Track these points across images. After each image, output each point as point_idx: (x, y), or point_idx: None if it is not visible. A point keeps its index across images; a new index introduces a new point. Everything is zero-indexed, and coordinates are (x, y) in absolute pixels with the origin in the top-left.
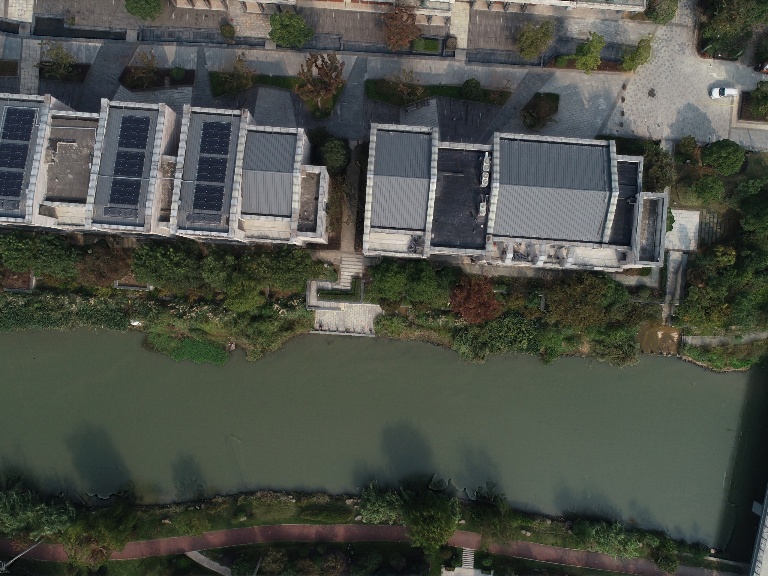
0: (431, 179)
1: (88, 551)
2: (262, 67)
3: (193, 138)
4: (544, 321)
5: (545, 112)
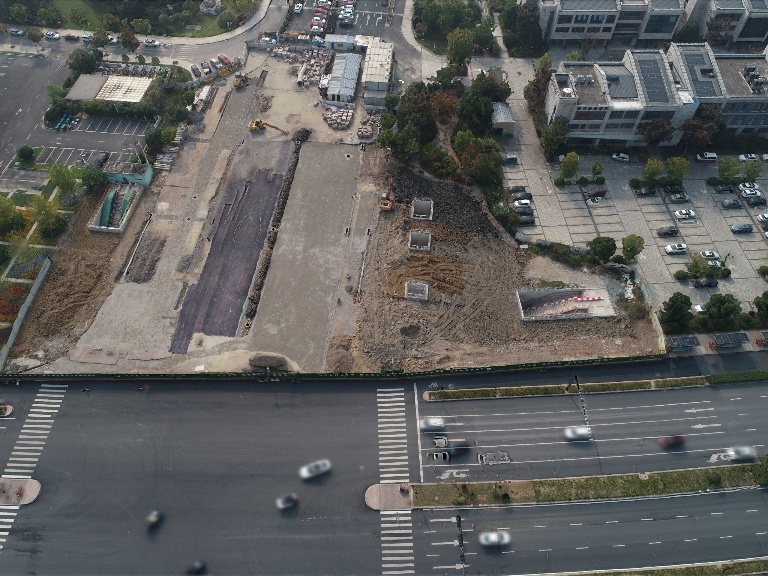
0: None
1: None
2: None
3: None
4: None
5: None
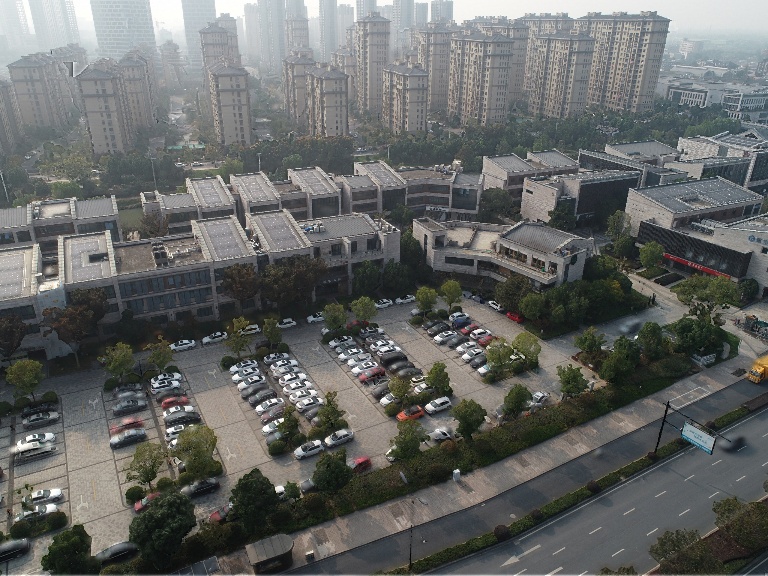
0: None
1: (226, 159)
2: None
3: (225, 198)
4: None
5: None
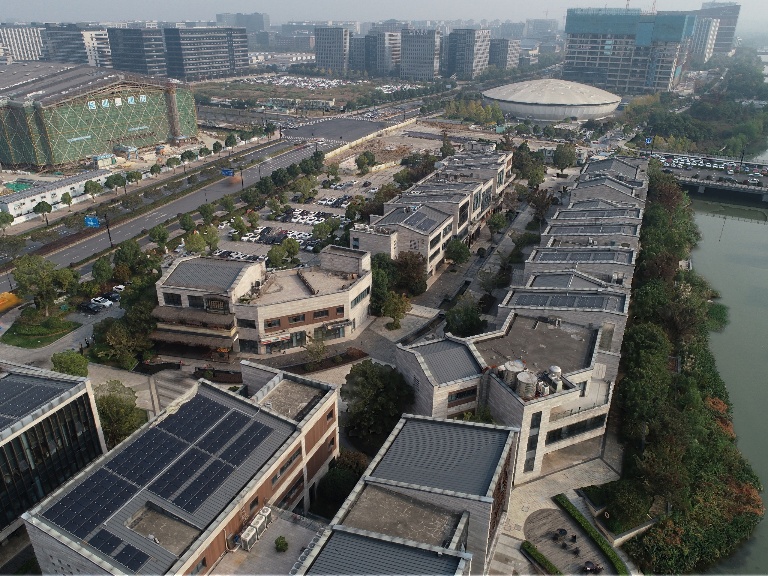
0: (607, 176)
1: None
2: (507, 250)
3: None
4: (672, 219)
5: None
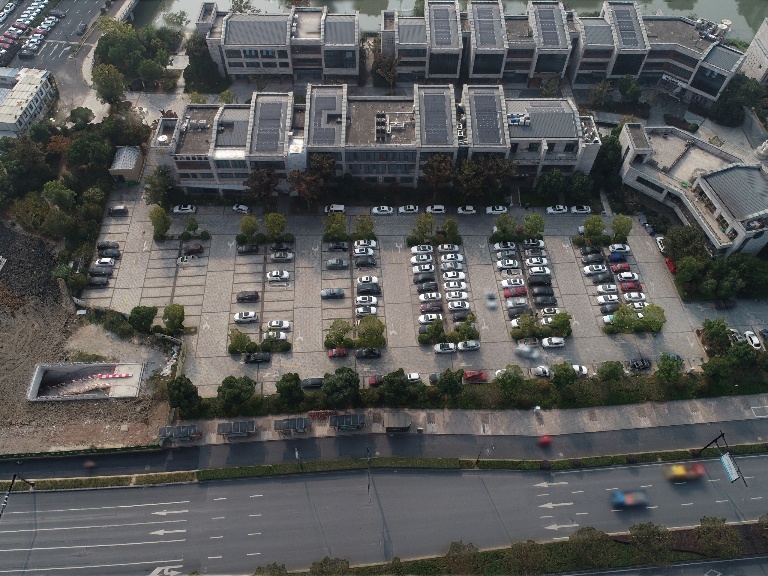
0: None
1: None
2: None
3: (455, 38)
4: None
5: None
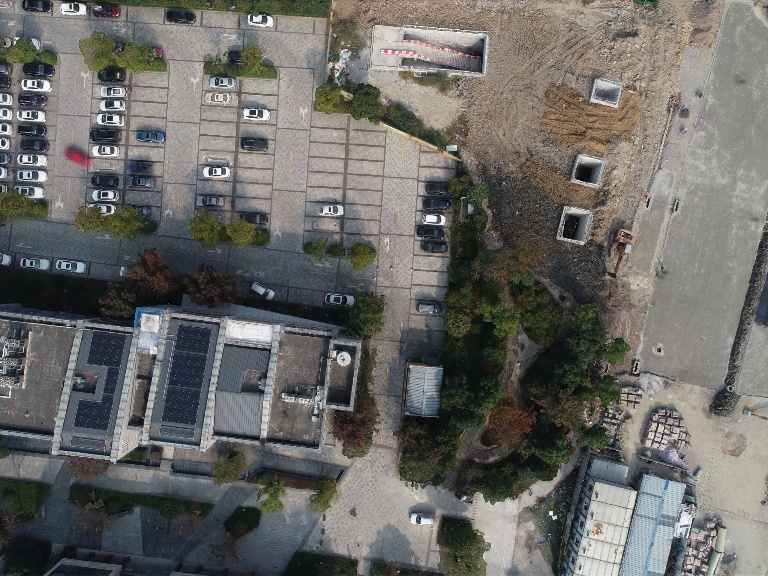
0: None
1: None
2: None
3: None
4: None
5: (242, 532)
